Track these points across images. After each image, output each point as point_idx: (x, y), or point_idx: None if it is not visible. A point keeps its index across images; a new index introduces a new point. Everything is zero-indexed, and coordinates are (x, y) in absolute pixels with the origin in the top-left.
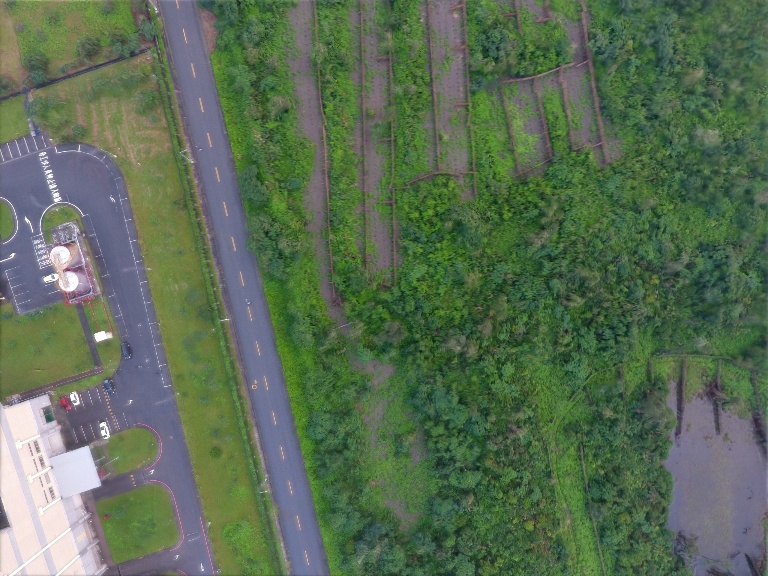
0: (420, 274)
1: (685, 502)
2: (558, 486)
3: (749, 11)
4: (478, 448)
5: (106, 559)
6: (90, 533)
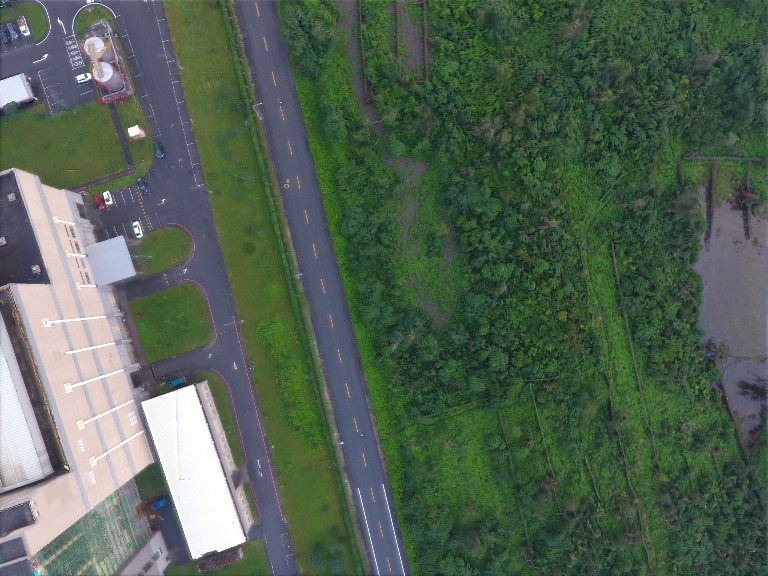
0: (452, 70)
1: (715, 306)
2: (590, 283)
3: None
4: (510, 241)
5: (139, 358)
6: None
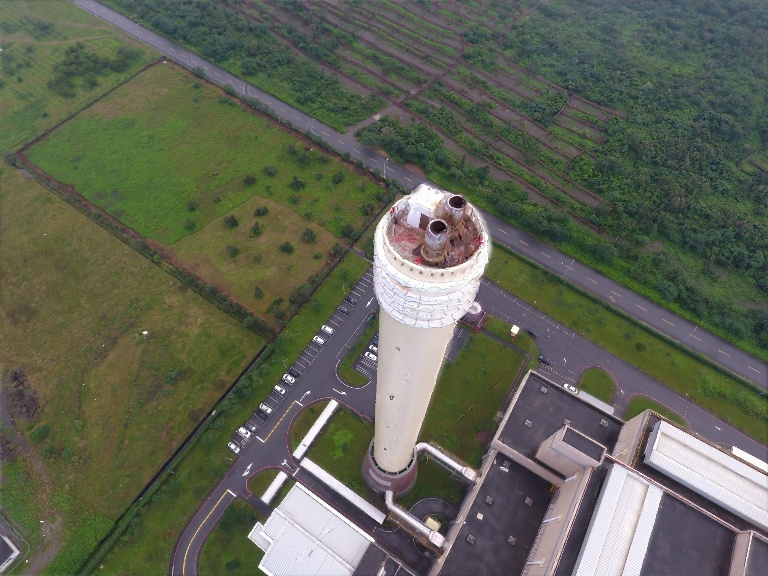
0: None
1: None
2: None
3: (605, 51)
4: (741, 243)
5: None
6: None
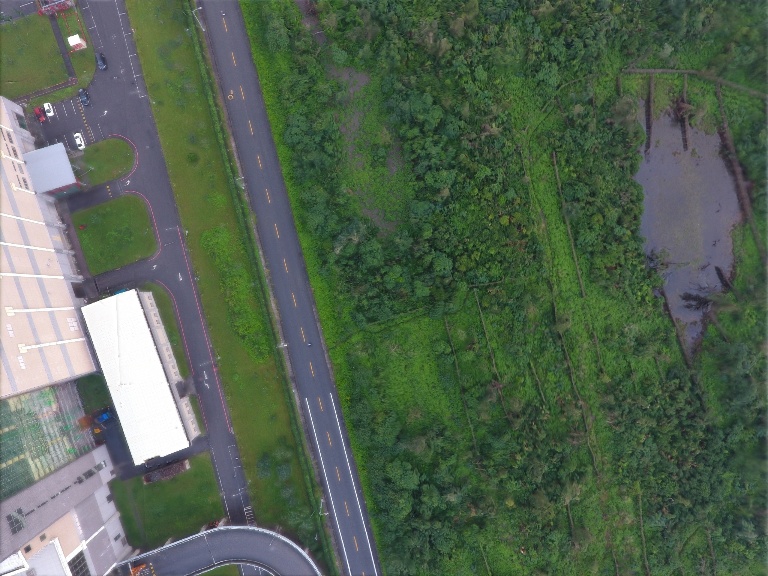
0: None
1: (656, 216)
2: (532, 191)
3: None
4: (453, 149)
5: (82, 271)
6: (65, 240)
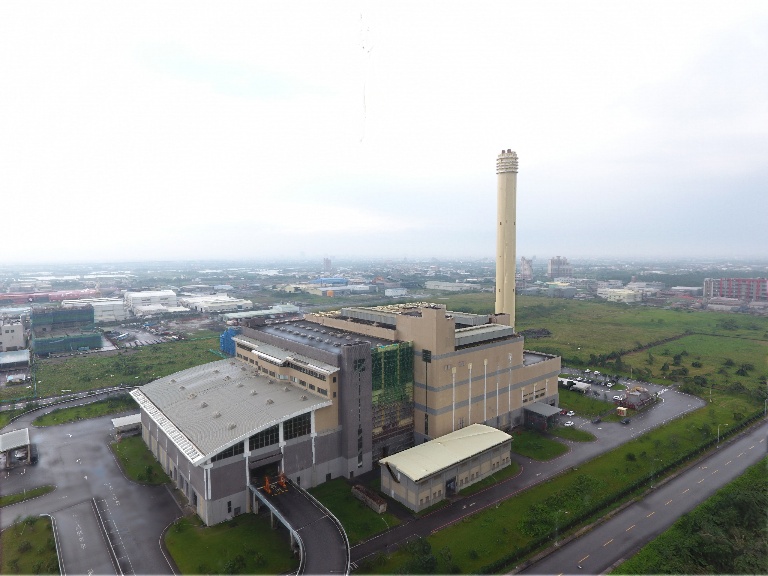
0: None
1: None
2: None
3: None
4: None
5: None
6: None
